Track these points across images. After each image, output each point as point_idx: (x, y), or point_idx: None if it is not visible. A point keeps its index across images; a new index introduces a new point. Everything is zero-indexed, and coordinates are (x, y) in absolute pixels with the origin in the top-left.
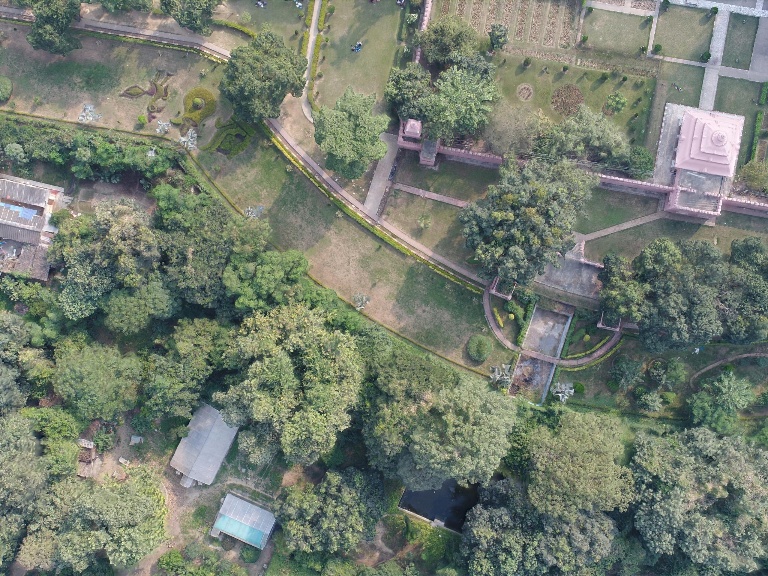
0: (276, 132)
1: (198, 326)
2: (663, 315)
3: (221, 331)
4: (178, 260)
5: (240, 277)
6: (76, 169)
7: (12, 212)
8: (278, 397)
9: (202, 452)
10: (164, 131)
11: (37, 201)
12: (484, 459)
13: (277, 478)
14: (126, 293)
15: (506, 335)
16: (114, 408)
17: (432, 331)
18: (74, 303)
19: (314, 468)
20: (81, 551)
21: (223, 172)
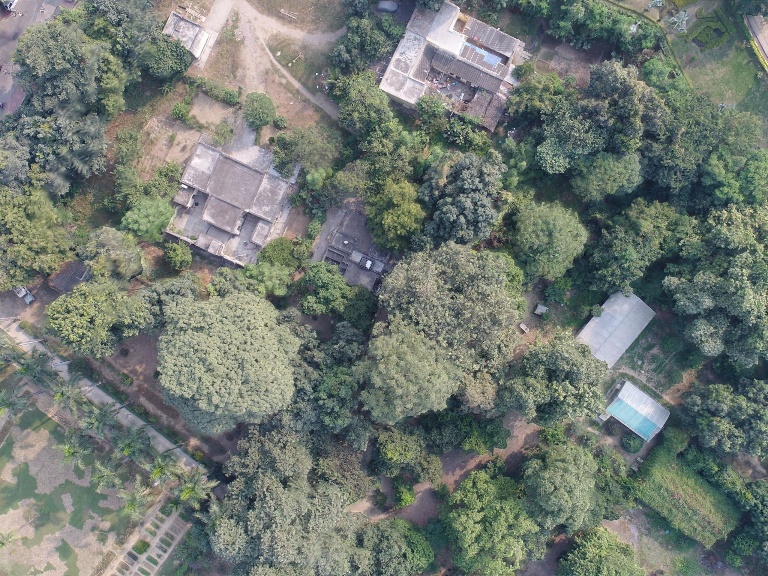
0: (754, 36)
1: (659, 208)
2: None
3: (684, 218)
4: (663, 137)
5: (726, 168)
6: (565, 24)
7: (477, 54)
8: (760, 292)
9: (613, 335)
10: (644, 8)
11: (504, 49)
12: None
13: (680, 376)
14: (615, 157)
15: None
16: (561, 270)
17: None
18: (555, 156)
19: (709, 375)
20: (541, 398)
21: (693, 63)
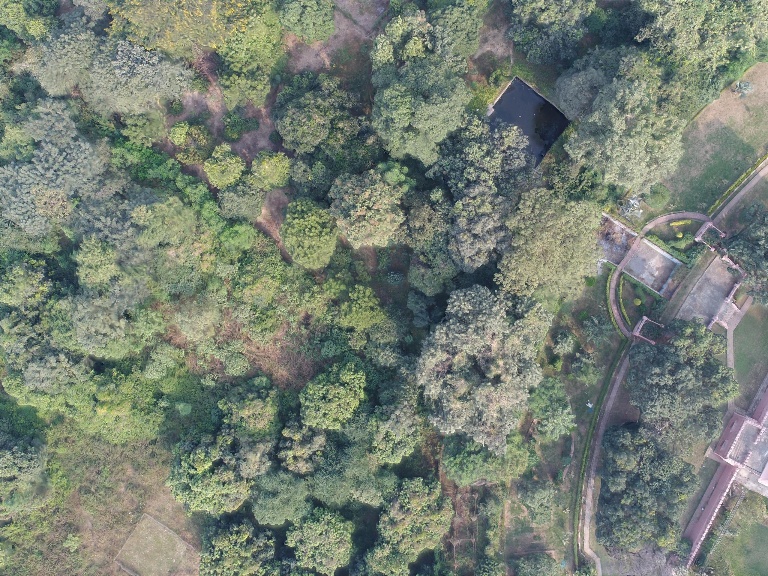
0: None
1: None
2: (677, 366)
3: None
4: None
5: None
6: None
7: None
8: None
9: None
10: None
11: None
12: (618, 142)
13: None
14: None
15: (660, 226)
16: None
17: (685, 154)
18: None
19: None
20: None
21: None
